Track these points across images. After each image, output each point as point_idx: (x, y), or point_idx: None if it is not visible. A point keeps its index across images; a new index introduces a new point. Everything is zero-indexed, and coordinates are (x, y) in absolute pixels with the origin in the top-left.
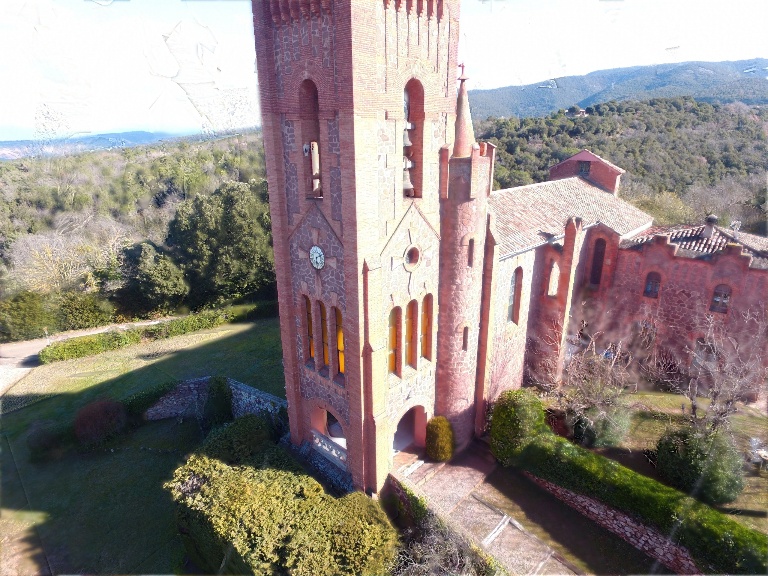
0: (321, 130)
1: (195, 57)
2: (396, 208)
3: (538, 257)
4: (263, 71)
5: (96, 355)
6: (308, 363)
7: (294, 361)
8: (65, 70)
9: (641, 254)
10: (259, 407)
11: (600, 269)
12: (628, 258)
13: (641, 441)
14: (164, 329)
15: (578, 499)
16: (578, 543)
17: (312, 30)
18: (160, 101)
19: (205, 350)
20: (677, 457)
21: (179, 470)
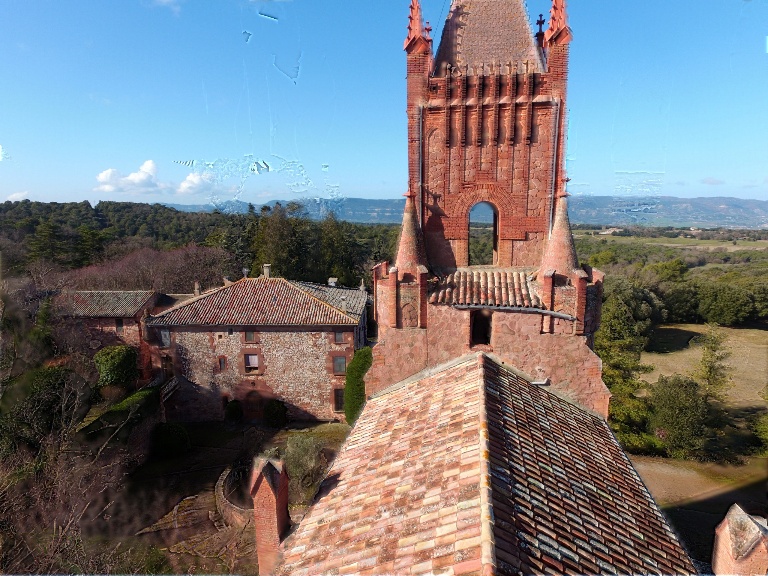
0: None
1: None
2: None
3: None
4: None
5: None
6: None
7: None
8: None
9: None
10: None
11: None
12: None
13: None
14: None
15: None
16: None
17: None
18: None
19: None
20: None
21: None
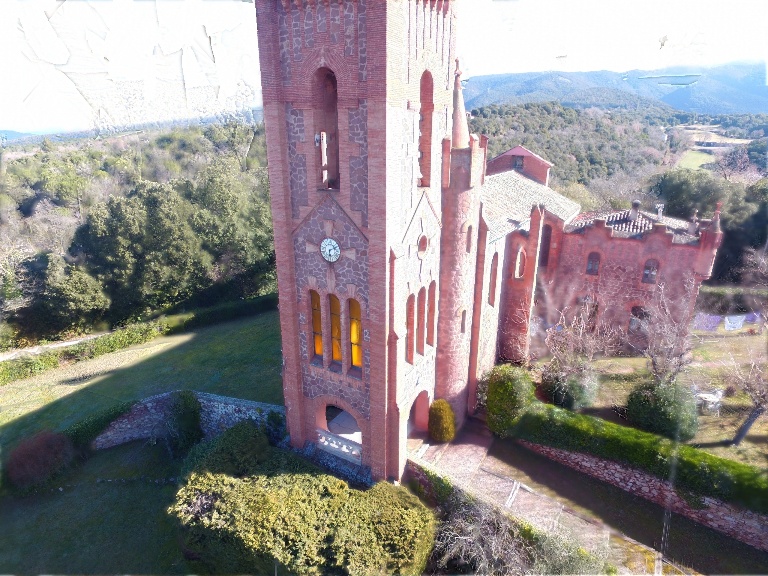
0: (340, 119)
1: (83, 43)
2: (413, 197)
3: (507, 243)
4: (267, 57)
5: (2, 387)
6: (314, 360)
7: (297, 360)
8: None
9: (583, 237)
10: (239, 416)
11: (547, 252)
12: (572, 241)
13: (607, 400)
14: (87, 349)
15: (571, 457)
16: (580, 495)
17: (331, 17)
18: (37, 92)
19: (147, 366)
20: (648, 407)
21: (182, 492)
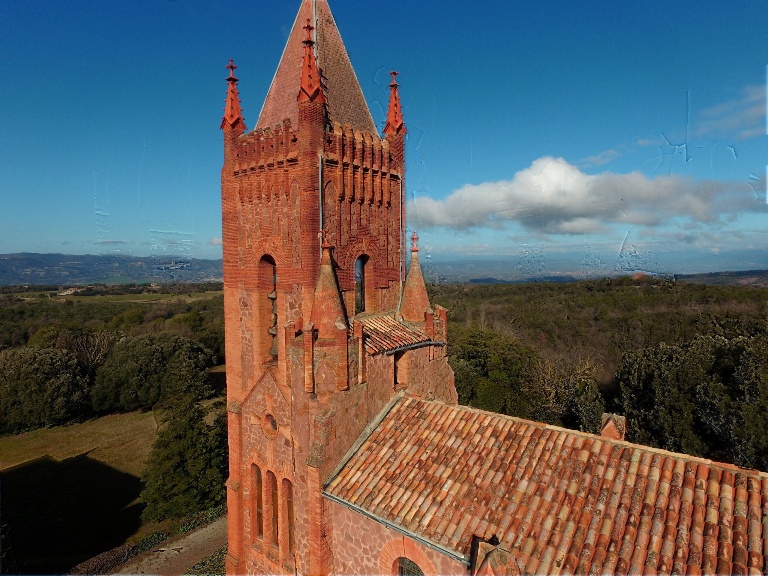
0: None
1: None
2: (255, 367)
3: None
4: None
5: None
6: None
7: None
8: (660, 214)
9: None
10: None
11: None
12: None
13: None
14: None
15: None
16: None
17: None
18: None
19: None
20: None
21: None
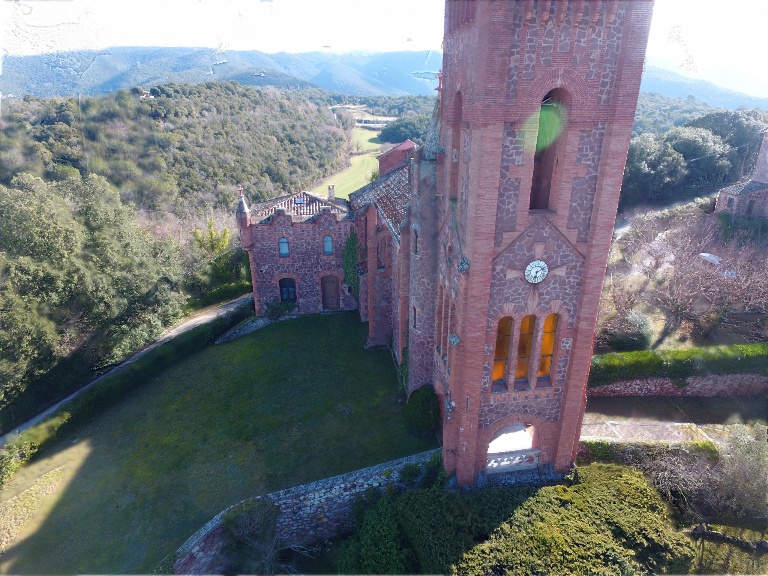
0: (570, 141)
1: None
2: None
3: None
4: (499, 73)
5: None
6: (494, 388)
7: None
8: None
9: None
10: (351, 493)
11: None
12: None
13: None
14: None
15: (609, 388)
16: (633, 411)
17: (576, 38)
18: None
19: (78, 512)
20: (630, 333)
21: None
